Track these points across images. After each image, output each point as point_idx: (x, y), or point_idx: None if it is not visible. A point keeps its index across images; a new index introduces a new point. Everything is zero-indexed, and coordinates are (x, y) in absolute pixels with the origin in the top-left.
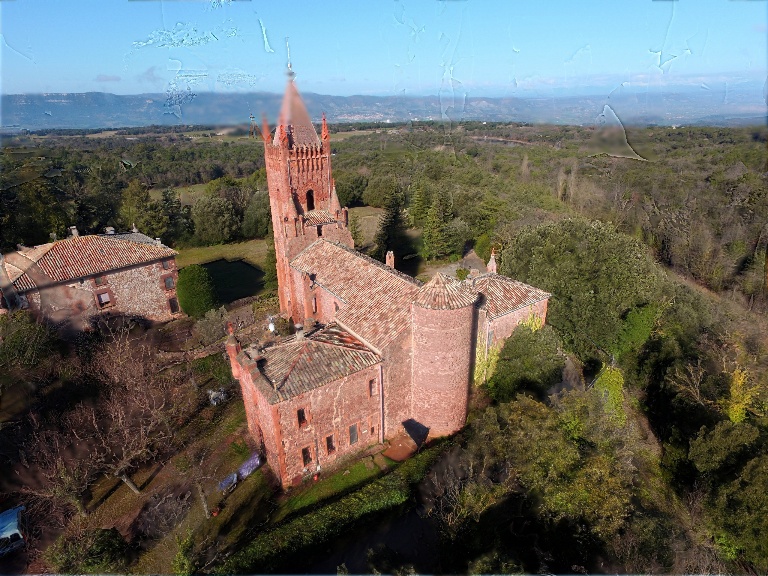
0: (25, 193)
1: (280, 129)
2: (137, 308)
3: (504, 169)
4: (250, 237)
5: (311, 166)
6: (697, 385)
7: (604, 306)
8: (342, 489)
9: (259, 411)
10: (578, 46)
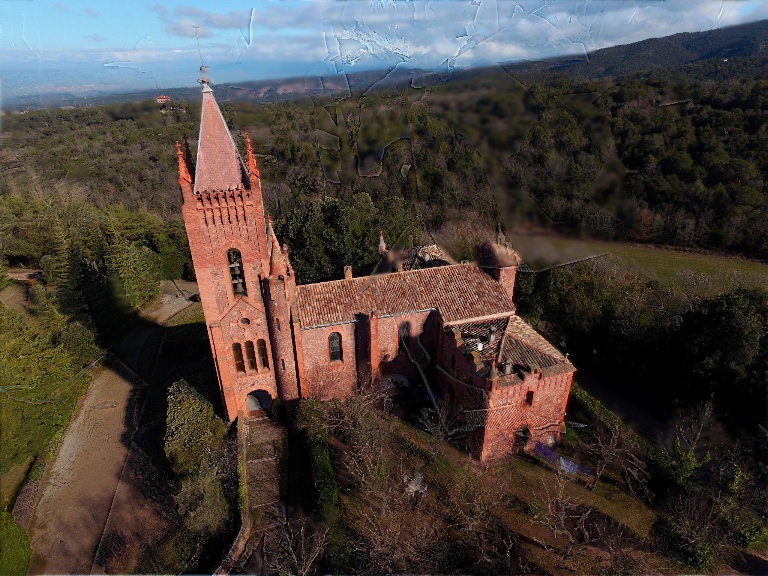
0: None
1: (250, 162)
2: None
3: None
4: None
5: None
6: None
7: None
8: None
9: (533, 405)
10: (139, 36)
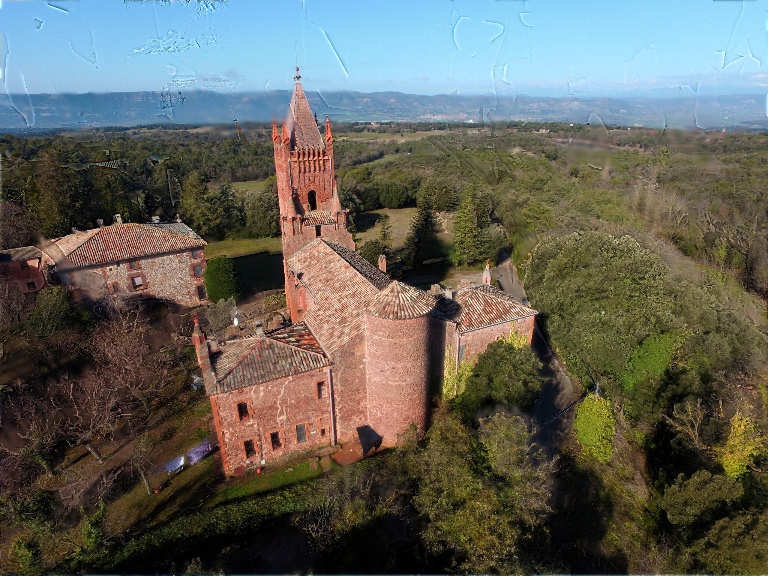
0: (97, 182)
1: None
2: (167, 292)
3: (557, 175)
4: None
5: (313, 167)
6: (696, 427)
7: (612, 329)
8: (279, 485)
9: None
10: (641, 45)
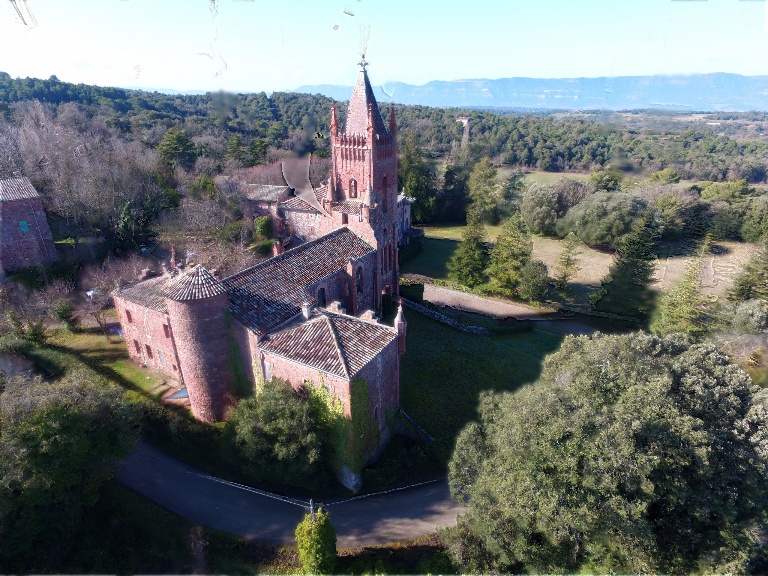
0: None
1: None
2: None
3: None
4: None
5: (353, 156)
6: None
7: None
8: (130, 380)
9: None
10: None
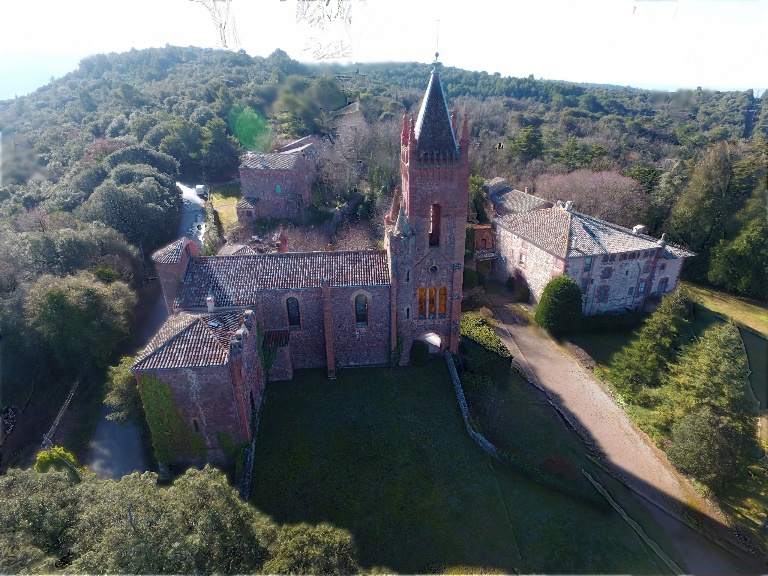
0: (756, 187)
1: None
2: None
3: None
4: None
5: None
6: None
7: None
8: None
9: None
10: None
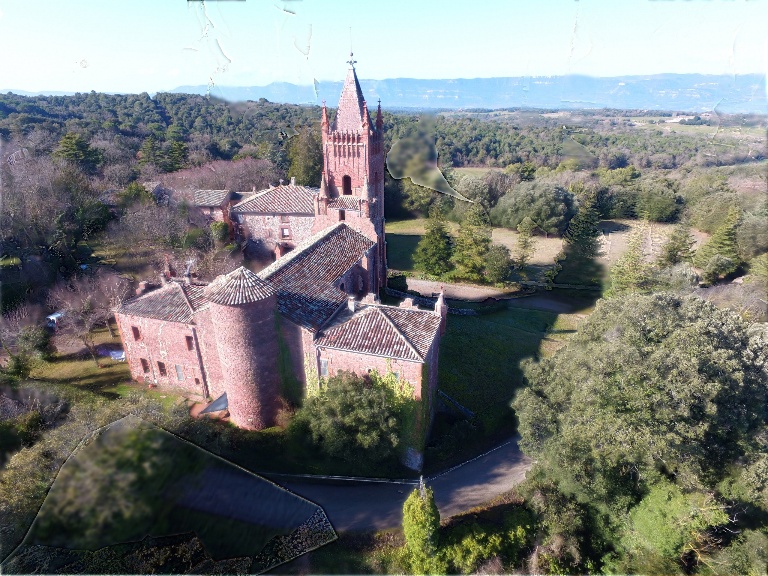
0: None
1: None
2: None
3: None
4: (502, 225)
5: (347, 152)
6: None
7: None
8: None
9: None
10: None
